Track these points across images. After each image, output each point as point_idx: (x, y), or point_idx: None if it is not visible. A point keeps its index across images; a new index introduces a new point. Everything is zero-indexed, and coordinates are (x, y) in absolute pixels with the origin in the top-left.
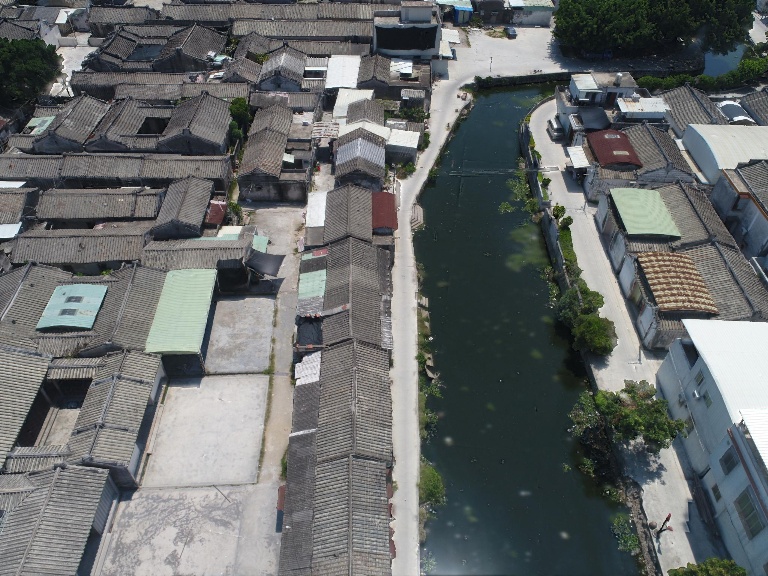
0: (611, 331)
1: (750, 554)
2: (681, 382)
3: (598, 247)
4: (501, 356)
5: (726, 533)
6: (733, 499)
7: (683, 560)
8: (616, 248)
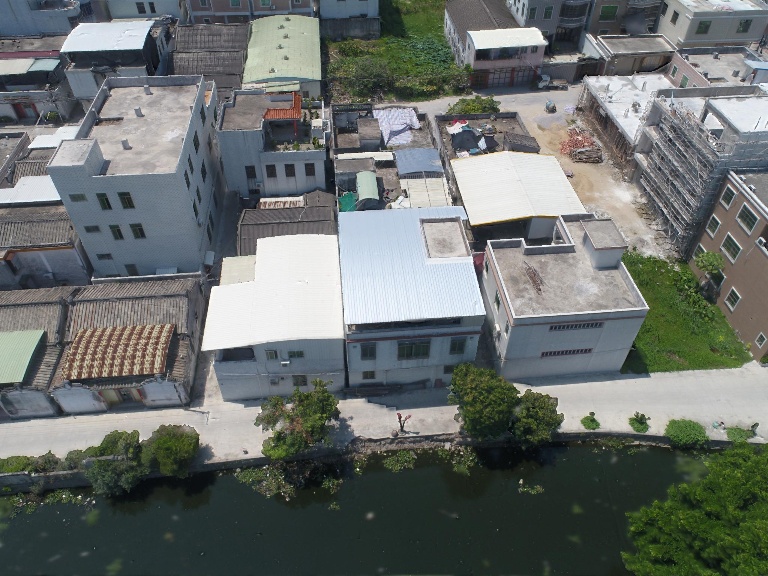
0: (176, 429)
1: (435, 362)
2: (259, 375)
3: (1, 429)
4: (174, 575)
5: (400, 379)
6: (394, 360)
7: (421, 417)
8: (23, 405)
